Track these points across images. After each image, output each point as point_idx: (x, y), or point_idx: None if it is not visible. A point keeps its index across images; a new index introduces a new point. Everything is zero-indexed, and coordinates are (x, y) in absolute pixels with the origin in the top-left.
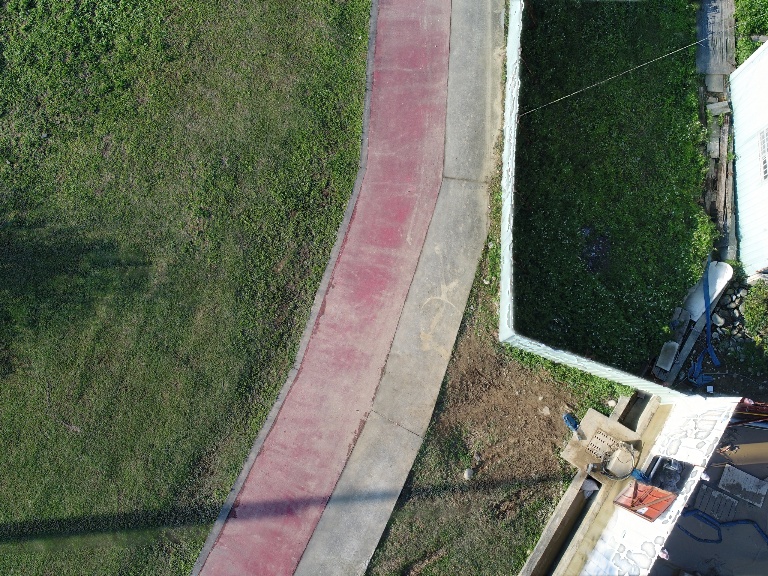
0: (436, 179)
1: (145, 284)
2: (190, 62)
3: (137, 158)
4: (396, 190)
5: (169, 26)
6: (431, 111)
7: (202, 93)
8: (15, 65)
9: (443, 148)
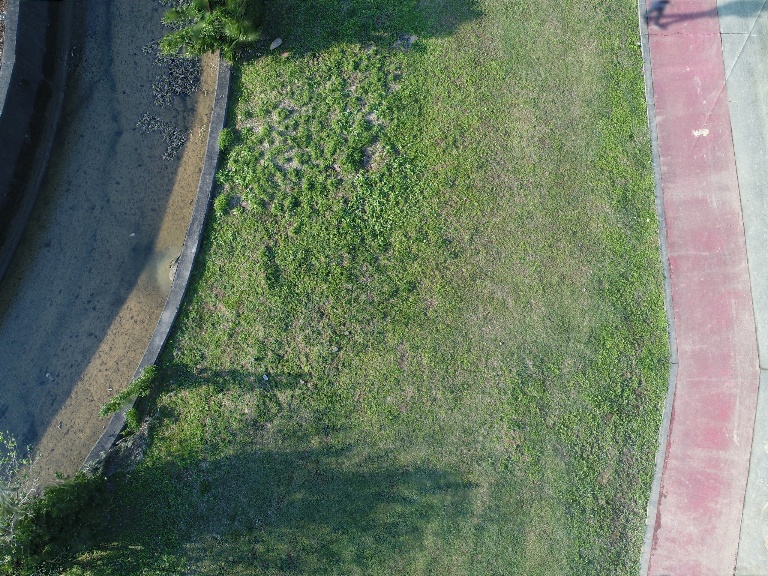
0: (753, 371)
1: (468, 507)
2: (474, 258)
3: (437, 368)
4: (714, 386)
5: (446, 219)
6: (736, 297)
7: (492, 291)
8: (291, 272)
9: (755, 337)
